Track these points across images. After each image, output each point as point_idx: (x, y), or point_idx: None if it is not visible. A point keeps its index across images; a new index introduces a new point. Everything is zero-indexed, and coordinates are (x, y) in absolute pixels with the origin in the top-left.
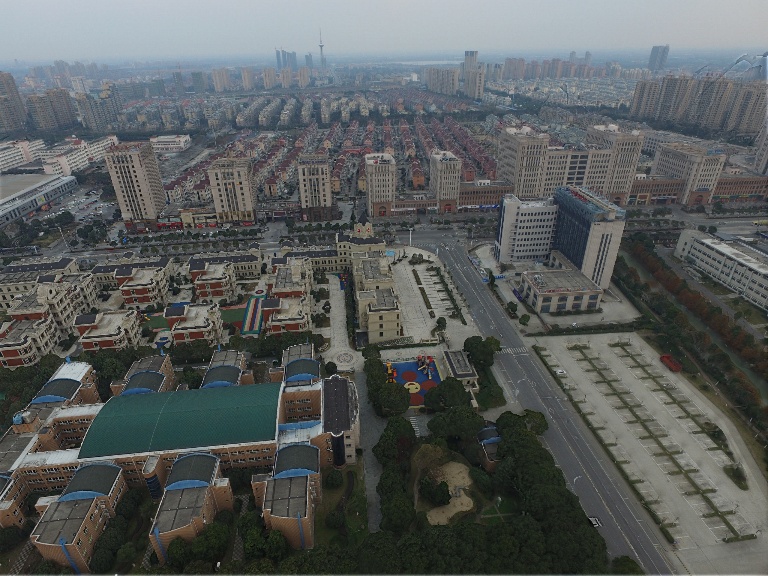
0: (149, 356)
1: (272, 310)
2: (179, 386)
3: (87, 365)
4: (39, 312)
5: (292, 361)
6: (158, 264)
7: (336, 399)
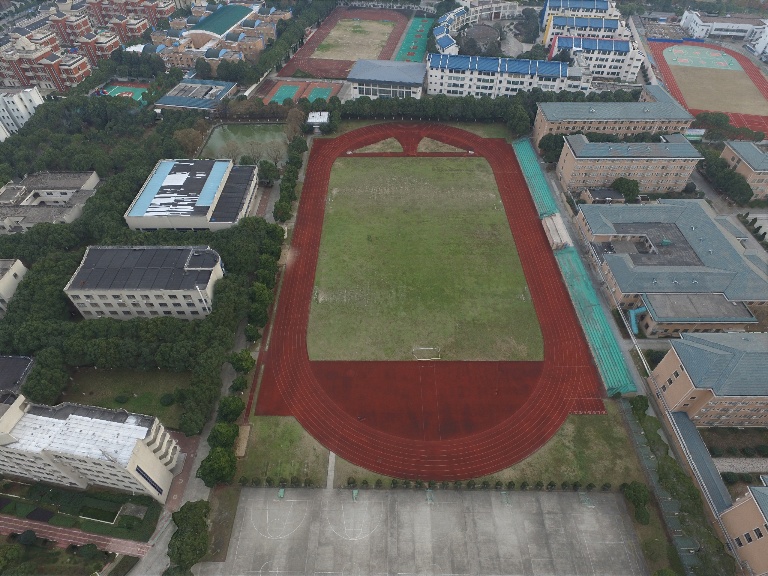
0: (141, 42)
1: (155, 5)
2: (190, 27)
3: (136, 45)
4: (48, 50)
5: (206, 7)
6: (7, 38)
7: (243, 2)
